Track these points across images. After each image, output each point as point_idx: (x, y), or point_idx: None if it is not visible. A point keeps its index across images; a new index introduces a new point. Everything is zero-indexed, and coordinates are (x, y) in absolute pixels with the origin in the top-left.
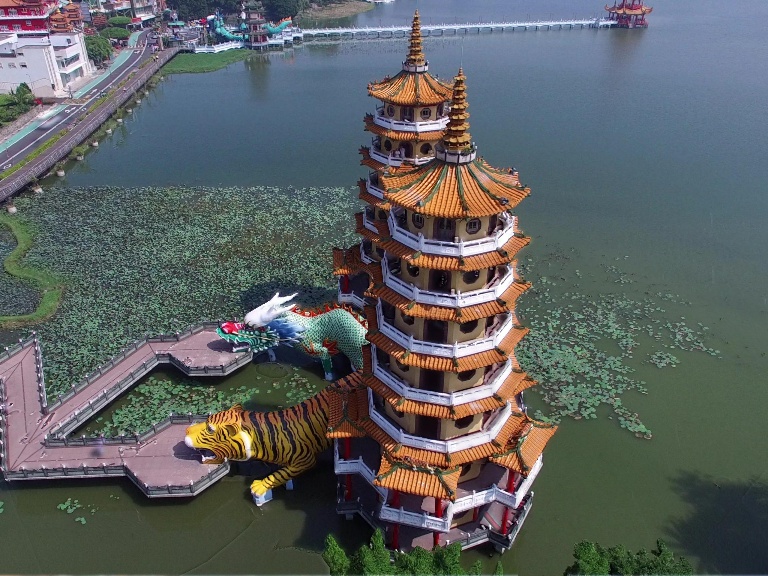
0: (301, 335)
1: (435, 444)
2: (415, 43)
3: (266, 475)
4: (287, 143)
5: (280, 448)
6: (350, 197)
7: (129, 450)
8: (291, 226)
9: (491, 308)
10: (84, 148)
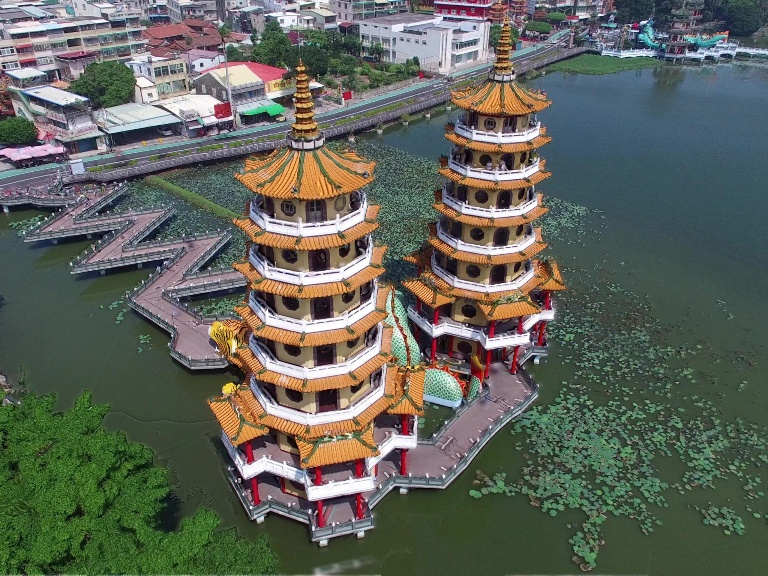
0: None
1: None
2: (501, 50)
3: None
4: None
5: None
6: (581, 218)
7: (193, 322)
8: None
9: (291, 290)
10: (416, 117)
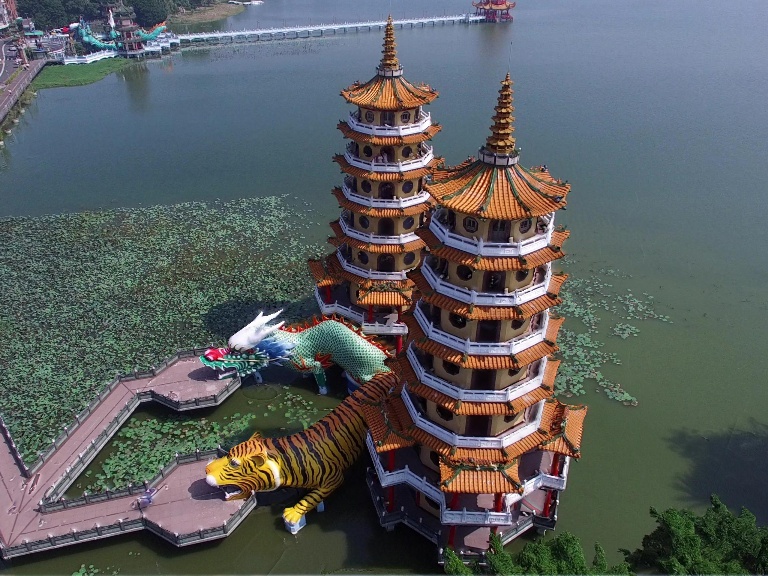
0: (291, 352)
1: (490, 441)
2: (389, 48)
3: (296, 501)
4: (193, 155)
5: (309, 471)
6: (284, 205)
7: None
8: (232, 241)
9: (544, 302)
10: None
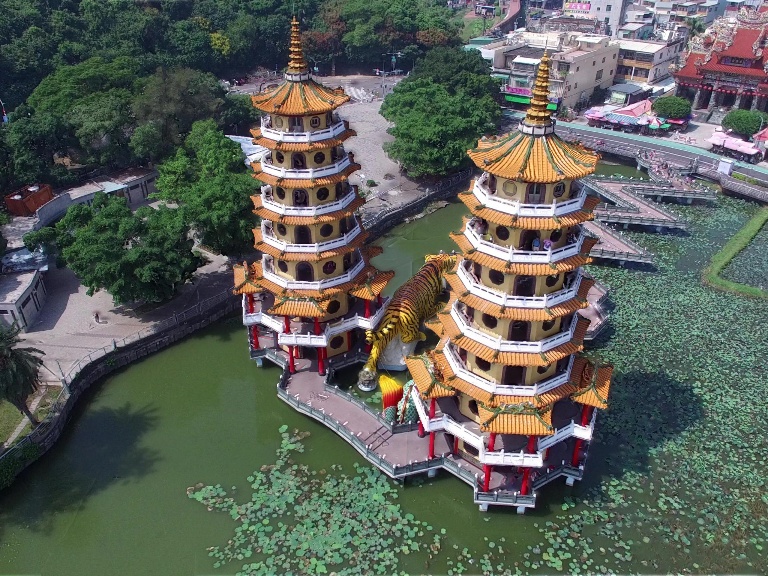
0: None
1: None
2: None
3: None
4: None
5: None
6: None
7: None
8: None
9: None
10: None
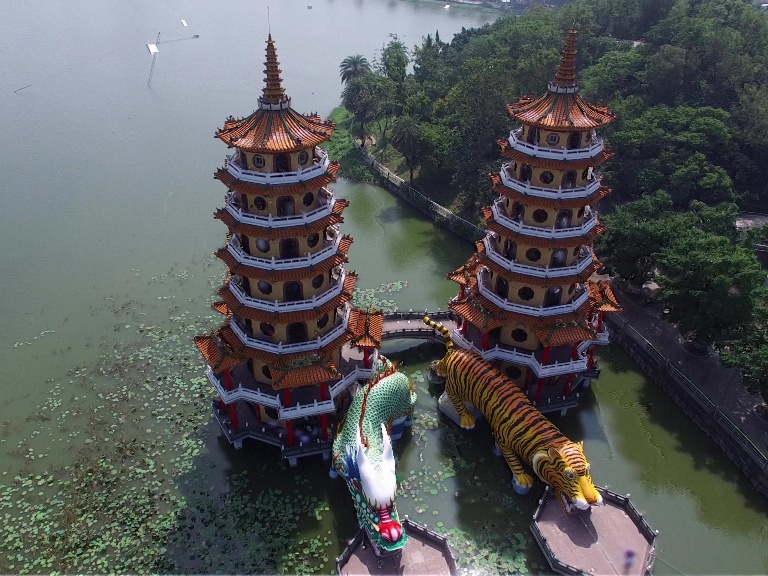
0: None
1: None
2: None
3: None
4: None
5: None
6: None
7: None
8: None
9: None
10: None
